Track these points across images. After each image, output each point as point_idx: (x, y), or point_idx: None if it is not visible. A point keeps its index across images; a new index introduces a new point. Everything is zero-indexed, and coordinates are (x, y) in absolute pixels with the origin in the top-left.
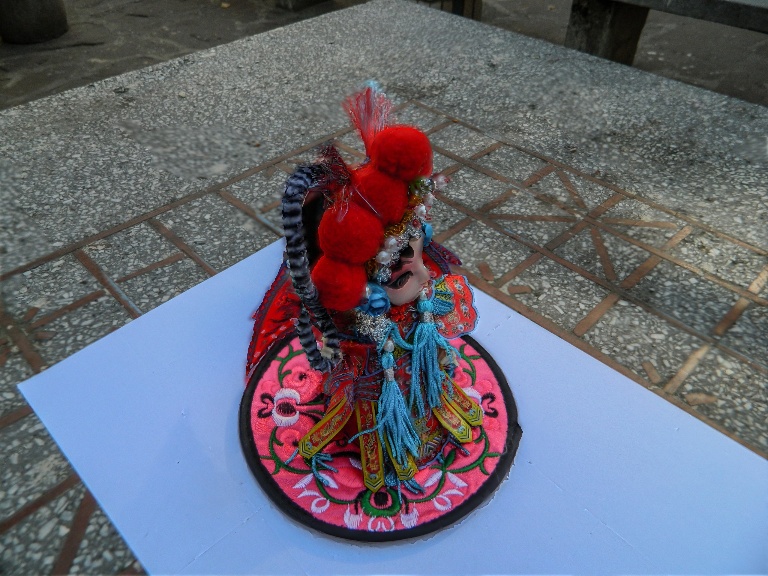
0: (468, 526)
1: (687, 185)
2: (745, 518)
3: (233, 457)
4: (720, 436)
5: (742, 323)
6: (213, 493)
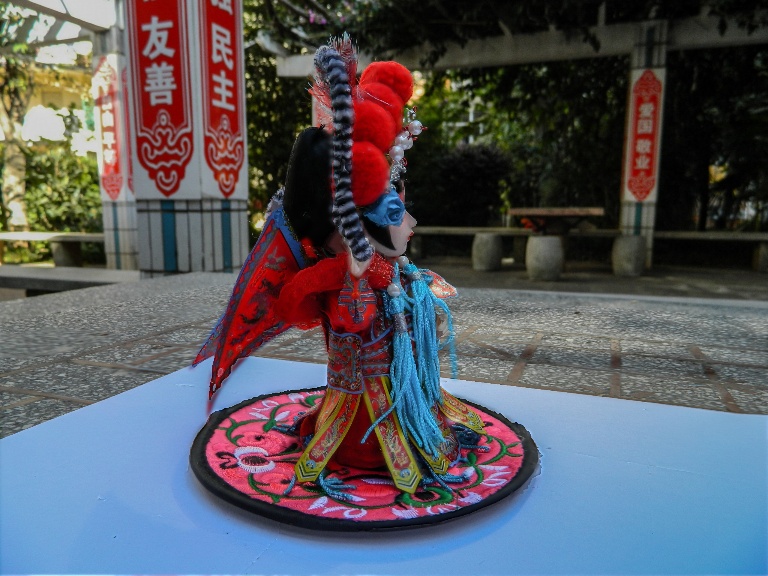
0: (534, 496)
1: (518, 319)
2: (750, 439)
3: (201, 515)
4: (679, 408)
5: (626, 362)
6: (188, 549)
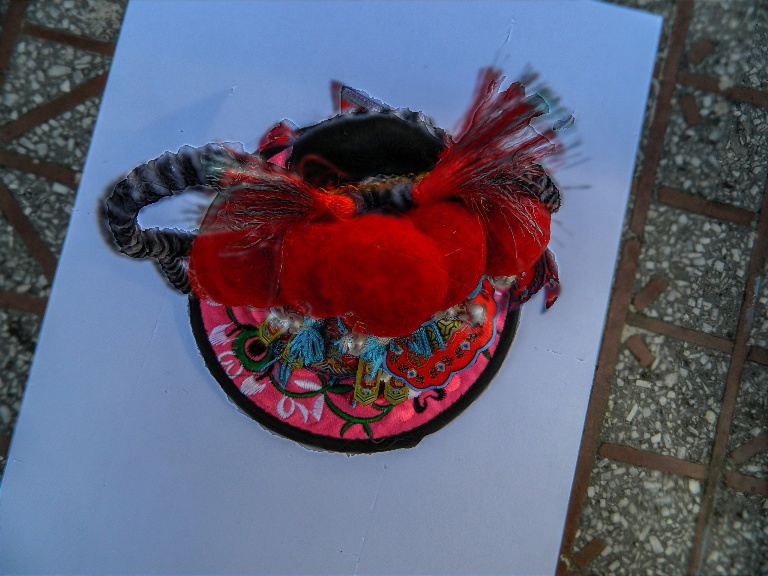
0: (281, 439)
1: None
2: None
3: None
4: None
5: None
6: None
